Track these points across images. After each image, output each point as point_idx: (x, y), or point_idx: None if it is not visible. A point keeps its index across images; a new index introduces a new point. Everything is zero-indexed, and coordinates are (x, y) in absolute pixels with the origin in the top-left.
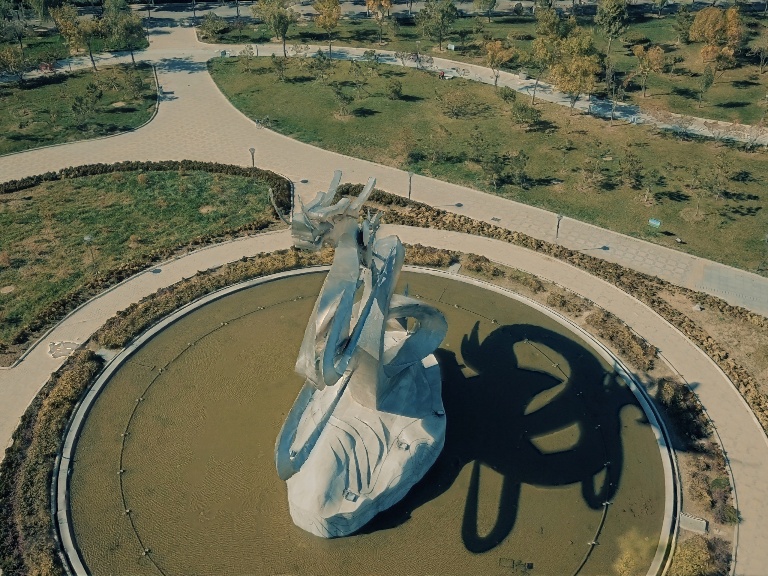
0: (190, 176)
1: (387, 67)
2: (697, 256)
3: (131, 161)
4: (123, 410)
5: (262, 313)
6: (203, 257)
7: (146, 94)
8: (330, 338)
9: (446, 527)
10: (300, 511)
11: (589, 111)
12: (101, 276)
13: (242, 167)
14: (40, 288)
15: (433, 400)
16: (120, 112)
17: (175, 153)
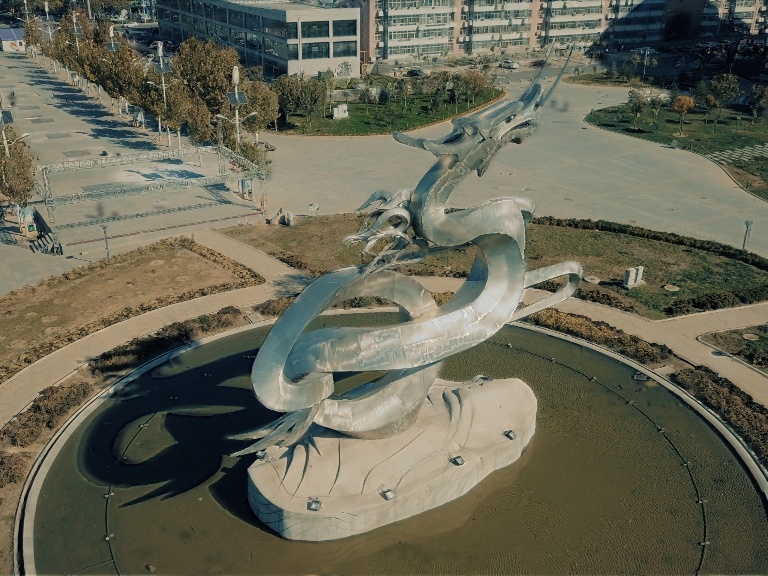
0: None
1: None
2: None
3: None
4: None
5: None
6: None
7: None
8: None
9: None
10: None
11: None
12: None
13: None
14: None
15: None
16: None
17: None
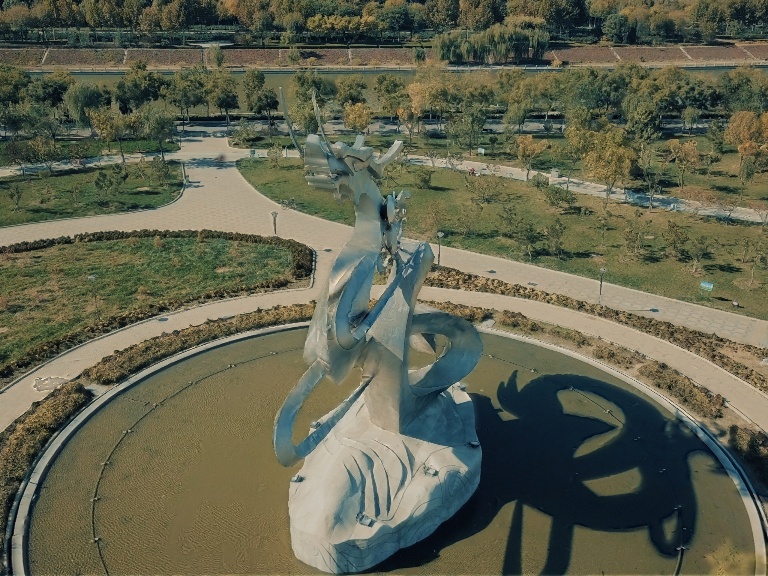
0: (208, 243)
1: (416, 167)
2: (758, 318)
3: (149, 230)
4: (107, 441)
5: (274, 358)
6: (214, 309)
7: (172, 182)
8: (345, 293)
9: (483, 568)
10: (303, 537)
11: (626, 201)
12: (102, 321)
13: (263, 236)
14: (35, 330)
15: (466, 434)
16: (144, 194)
17: (195, 226)
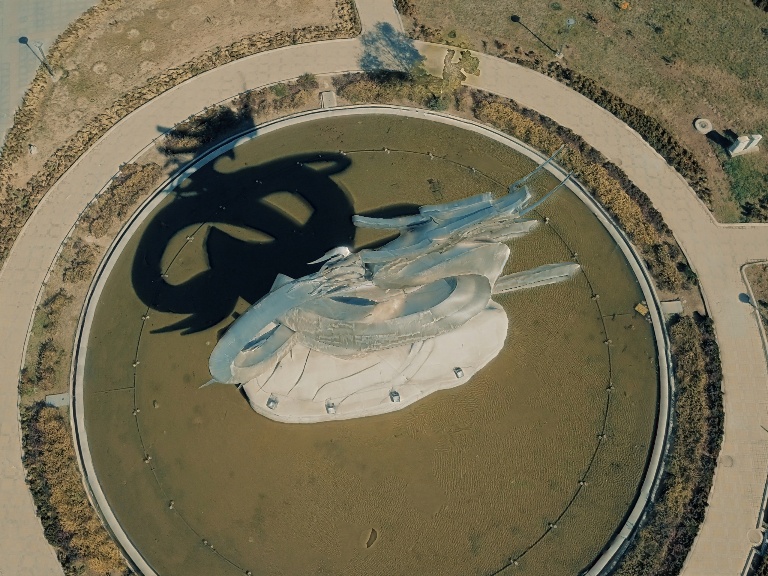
0: None
1: None
2: None
3: None
4: None
5: (257, 569)
6: None
7: None
8: None
9: None
10: None
11: None
12: None
13: None
14: None
15: None
16: None
17: None
